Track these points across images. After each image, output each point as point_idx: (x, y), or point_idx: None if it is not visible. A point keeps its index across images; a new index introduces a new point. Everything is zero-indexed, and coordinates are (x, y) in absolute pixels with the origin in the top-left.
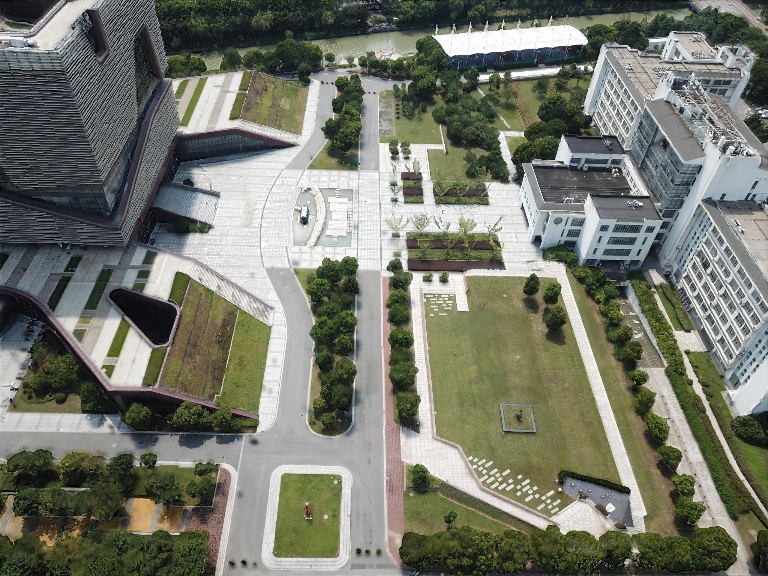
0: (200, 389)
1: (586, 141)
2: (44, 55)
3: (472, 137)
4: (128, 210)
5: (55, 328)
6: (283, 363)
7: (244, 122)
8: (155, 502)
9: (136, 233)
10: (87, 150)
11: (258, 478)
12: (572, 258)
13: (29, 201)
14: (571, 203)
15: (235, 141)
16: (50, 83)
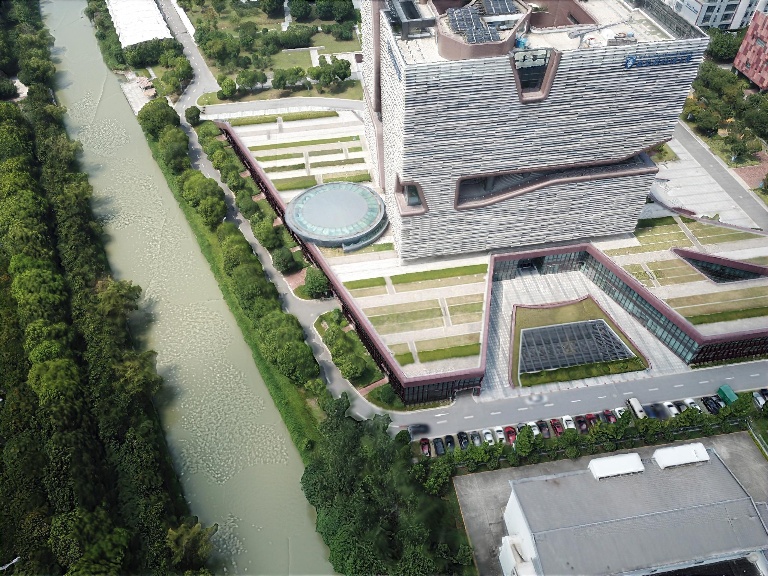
0: None
1: None
2: None
3: None
4: None
5: None
6: None
7: None
8: None
9: None
10: None
11: None
12: None
13: None
14: None
15: None
16: None
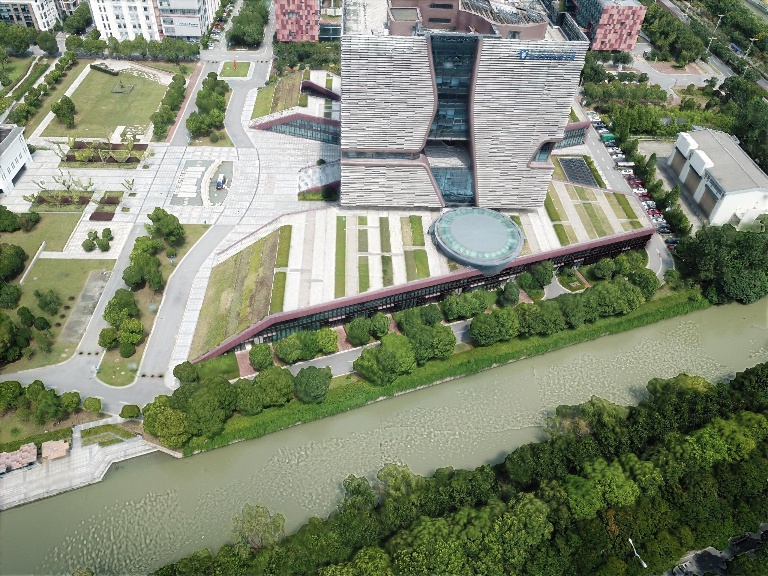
0: None
1: None
2: None
3: None
4: None
5: None
6: None
7: None
8: (297, 62)
9: None
10: None
11: None
12: None
13: None
14: None
15: None
16: None
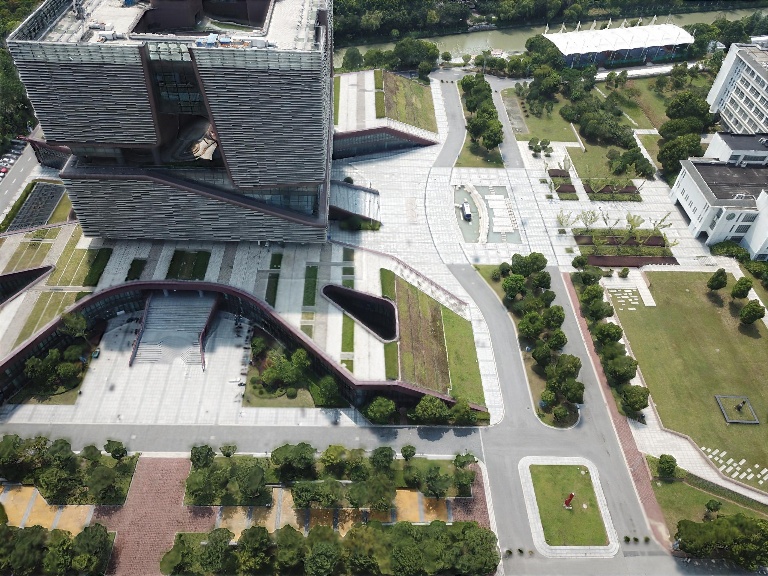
0: (434, 383)
1: (740, 138)
2: (306, 55)
3: (609, 135)
4: None
5: (269, 324)
6: (494, 357)
7: (390, 121)
8: (426, 493)
9: None
10: (318, 148)
11: (506, 469)
12: (745, 253)
13: (242, 199)
14: (743, 199)
15: (382, 139)
16: (303, 82)
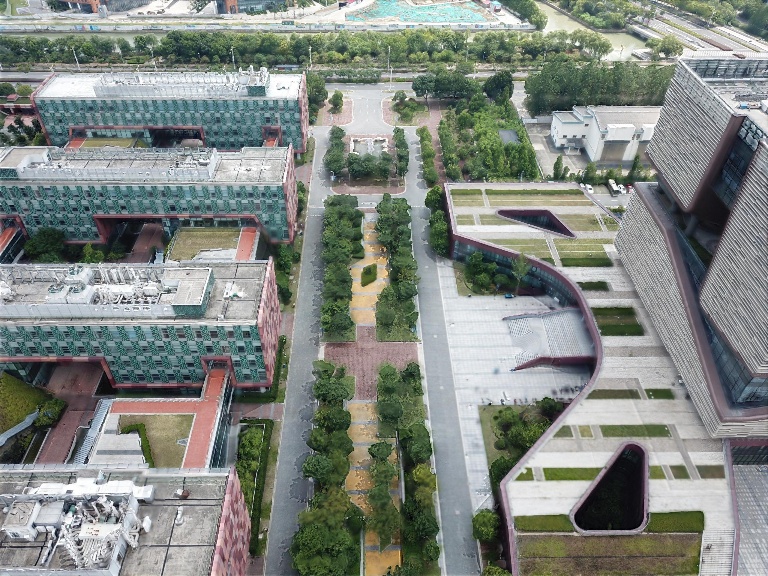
0: None
1: None
2: None
3: None
4: (762, 419)
5: None
6: None
7: None
8: (388, 572)
9: (749, 443)
10: None
11: None
12: None
13: (699, 319)
14: None
15: None
16: None
